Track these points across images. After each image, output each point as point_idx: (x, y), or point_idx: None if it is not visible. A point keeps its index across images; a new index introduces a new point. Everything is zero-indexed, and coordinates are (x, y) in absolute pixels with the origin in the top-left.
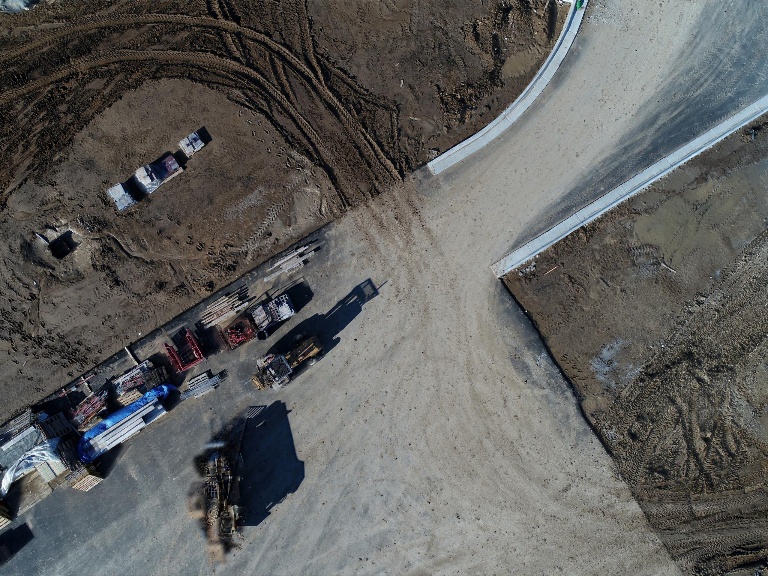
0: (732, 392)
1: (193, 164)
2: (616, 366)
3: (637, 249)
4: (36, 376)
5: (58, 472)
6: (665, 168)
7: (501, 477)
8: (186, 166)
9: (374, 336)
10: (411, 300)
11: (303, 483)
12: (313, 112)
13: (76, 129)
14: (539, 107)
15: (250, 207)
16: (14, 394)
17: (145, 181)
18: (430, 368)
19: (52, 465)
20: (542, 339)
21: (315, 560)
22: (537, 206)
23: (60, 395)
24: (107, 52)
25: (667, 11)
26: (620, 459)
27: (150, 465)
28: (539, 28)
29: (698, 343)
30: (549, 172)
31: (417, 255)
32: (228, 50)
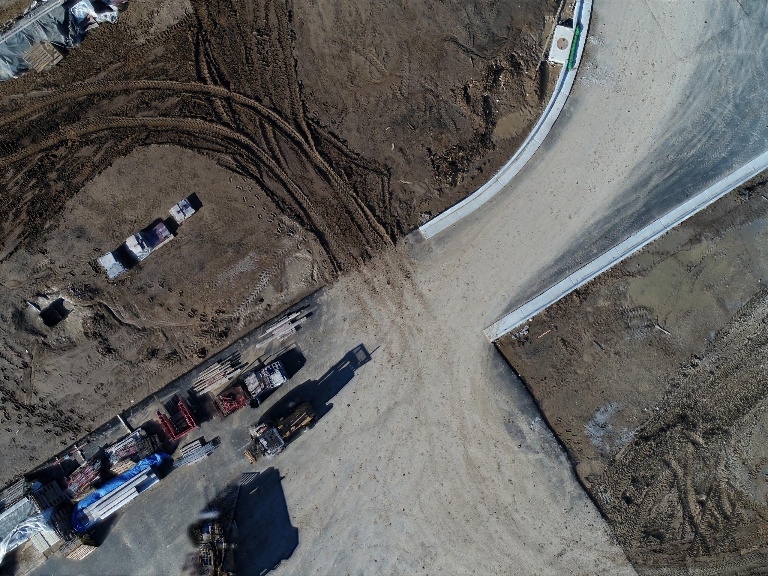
0: (727, 454)
1: (184, 230)
2: (610, 429)
3: (631, 311)
4: (29, 444)
5: (52, 542)
6: (659, 230)
7: (495, 542)
8: (177, 233)
9: (367, 401)
10: (404, 365)
11: (297, 549)
12: (304, 177)
13: (66, 197)
14: (531, 169)
15: (241, 273)
16: (7, 463)
17: (136, 250)
18: (423, 433)
19: (46, 535)
20: (536, 403)
21: None
22: (530, 269)
23: (53, 463)
24: (96, 119)
25: (660, 71)
26: (615, 522)
27: (144, 532)
28: (531, 90)
29: (693, 405)
30: (542, 235)
31: (409, 320)
32: (218, 116)
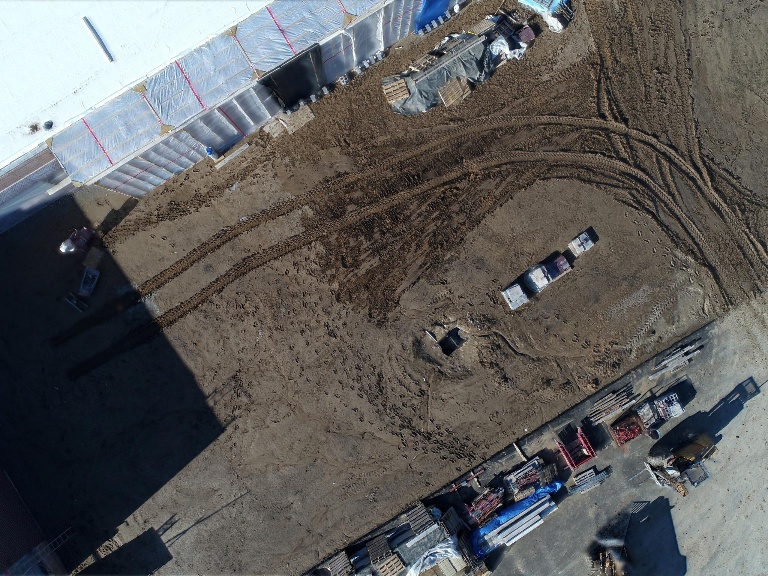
0: None
1: (580, 263)
2: None
3: None
4: (425, 471)
5: (459, 568)
6: None
7: None
8: (573, 265)
9: (755, 433)
10: None
11: None
12: (698, 213)
13: (468, 229)
14: None
15: (635, 306)
16: (404, 488)
17: (542, 282)
18: None
19: (453, 561)
20: None
21: None
22: None
23: (450, 490)
24: (499, 153)
25: None
26: None
27: (536, 559)
28: None
29: None
30: None
31: None
32: (616, 151)
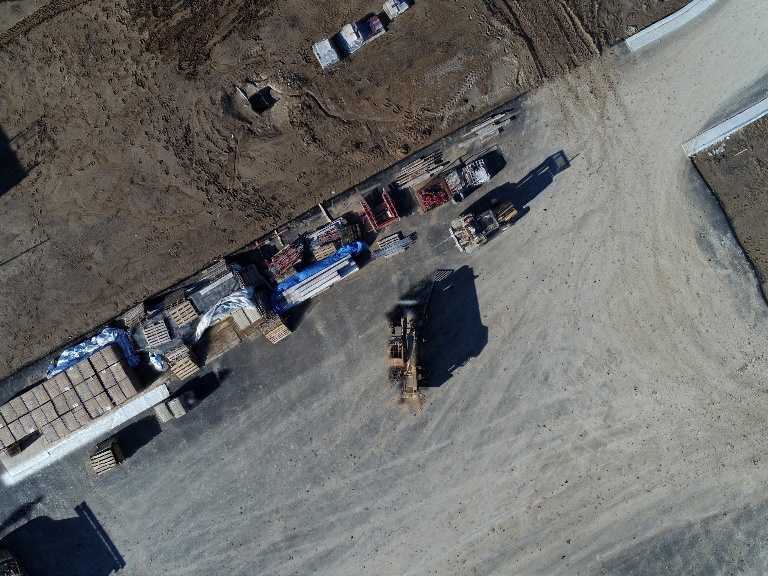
0: None
1: (395, 27)
2: None
3: None
4: (229, 228)
5: (253, 319)
6: None
7: (680, 353)
8: (388, 28)
9: (563, 207)
10: (601, 174)
11: (486, 348)
12: None
13: None
14: None
15: (448, 73)
16: (207, 244)
17: (351, 38)
18: (616, 242)
19: (247, 312)
20: (727, 220)
21: (494, 424)
22: (731, 88)
23: (253, 247)
24: None
25: None
26: None
27: (337, 322)
28: None
29: None
30: (744, 55)
31: (610, 130)
32: None
